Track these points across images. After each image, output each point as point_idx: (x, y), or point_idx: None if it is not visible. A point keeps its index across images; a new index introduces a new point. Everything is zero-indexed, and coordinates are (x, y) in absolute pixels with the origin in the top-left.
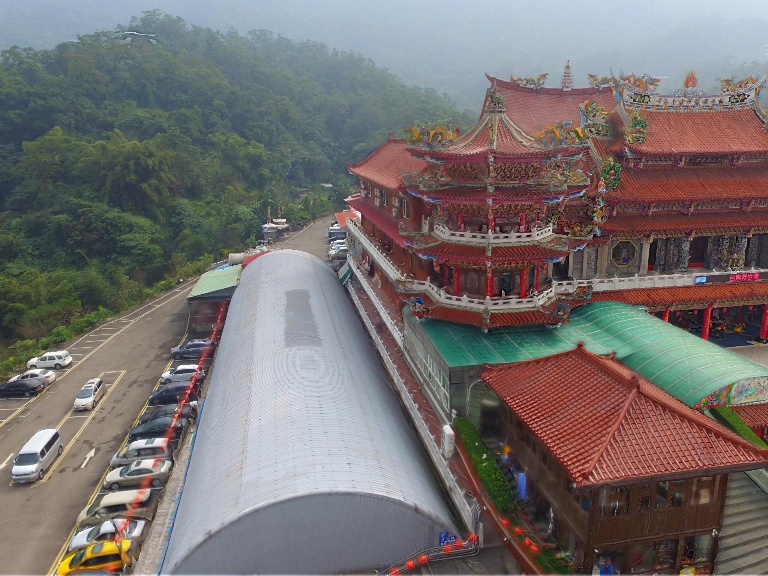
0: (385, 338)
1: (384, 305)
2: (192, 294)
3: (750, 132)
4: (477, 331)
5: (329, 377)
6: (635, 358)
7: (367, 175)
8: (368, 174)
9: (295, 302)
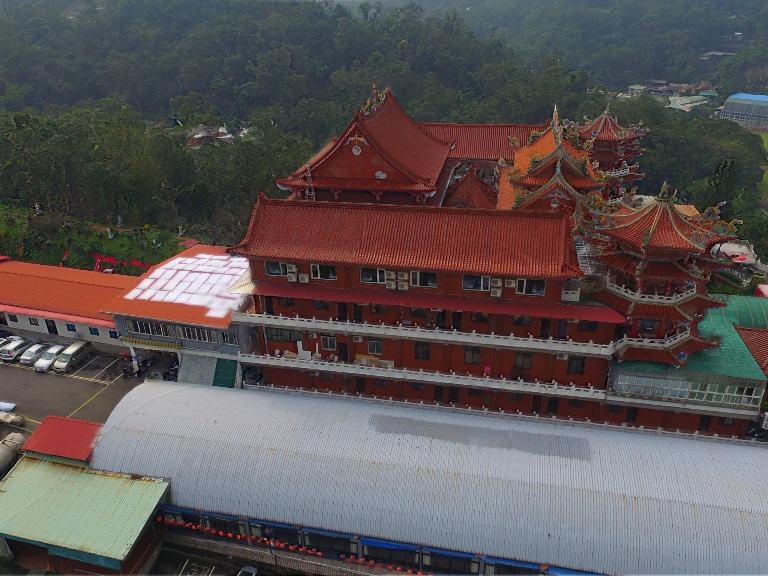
0: (466, 406)
1: (494, 378)
2: (112, 549)
3: (573, 149)
4: (702, 352)
5: (667, 448)
6: (744, 321)
7: (370, 261)
8: (362, 258)
9: (431, 431)
